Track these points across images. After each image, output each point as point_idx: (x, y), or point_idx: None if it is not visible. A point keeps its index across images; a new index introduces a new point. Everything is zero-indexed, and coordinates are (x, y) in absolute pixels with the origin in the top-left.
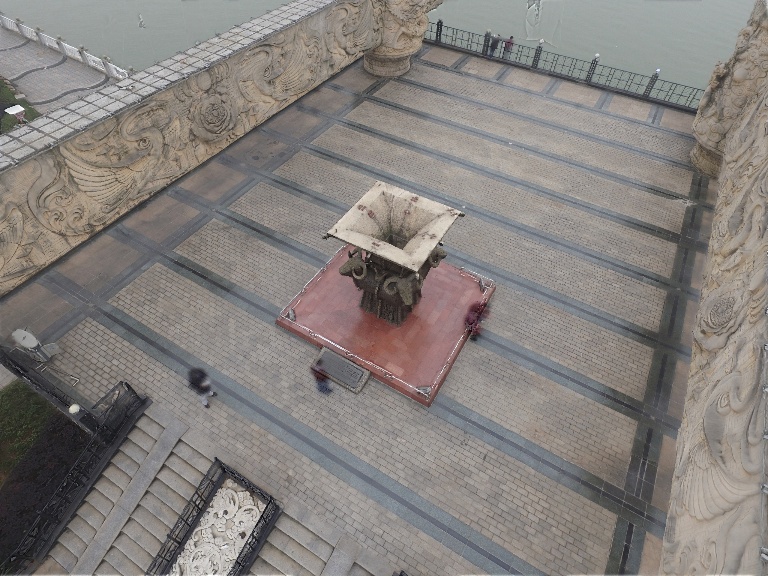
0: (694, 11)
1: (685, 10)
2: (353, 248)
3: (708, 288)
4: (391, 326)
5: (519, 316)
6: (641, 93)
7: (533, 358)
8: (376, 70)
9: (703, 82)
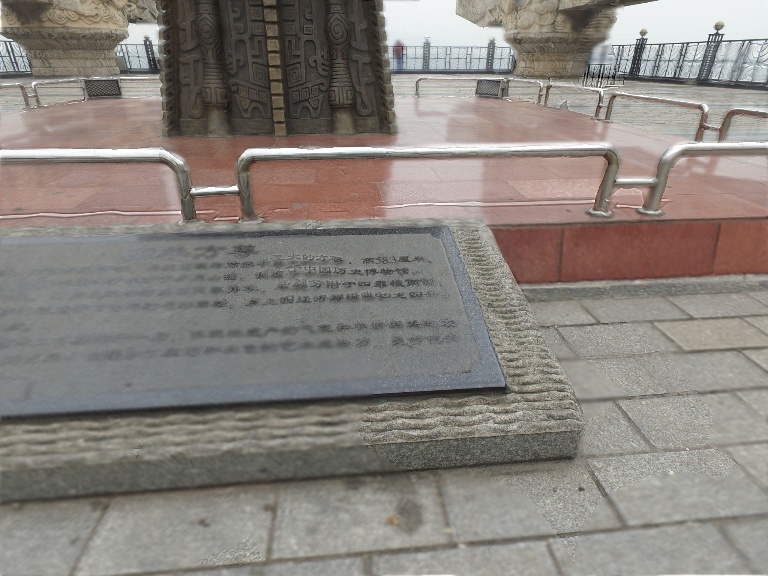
0: (416, 18)
1: (408, 19)
2: (70, 105)
3: None
4: (360, 137)
5: (613, 117)
6: (420, 68)
7: (767, 132)
8: (58, 67)
9: (472, 40)
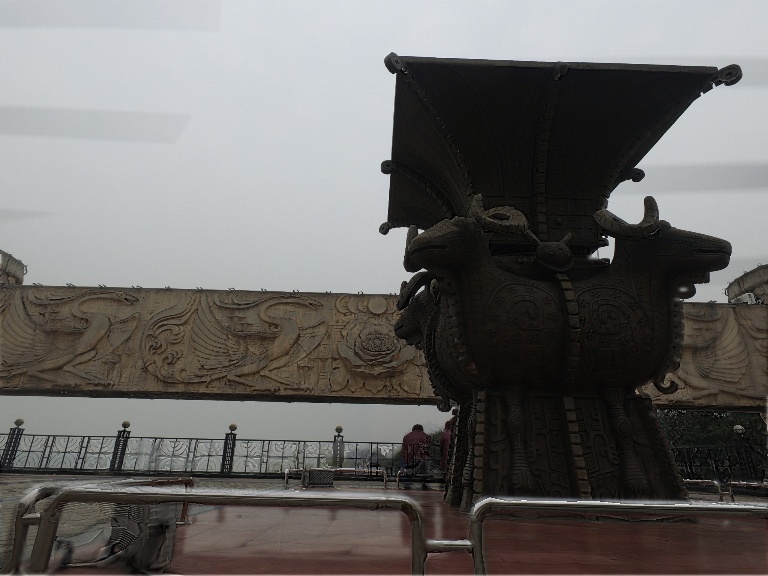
0: None
1: None
2: (384, 565)
3: (306, 381)
4: None
5: None
6: None
7: None
8: None
9: None
